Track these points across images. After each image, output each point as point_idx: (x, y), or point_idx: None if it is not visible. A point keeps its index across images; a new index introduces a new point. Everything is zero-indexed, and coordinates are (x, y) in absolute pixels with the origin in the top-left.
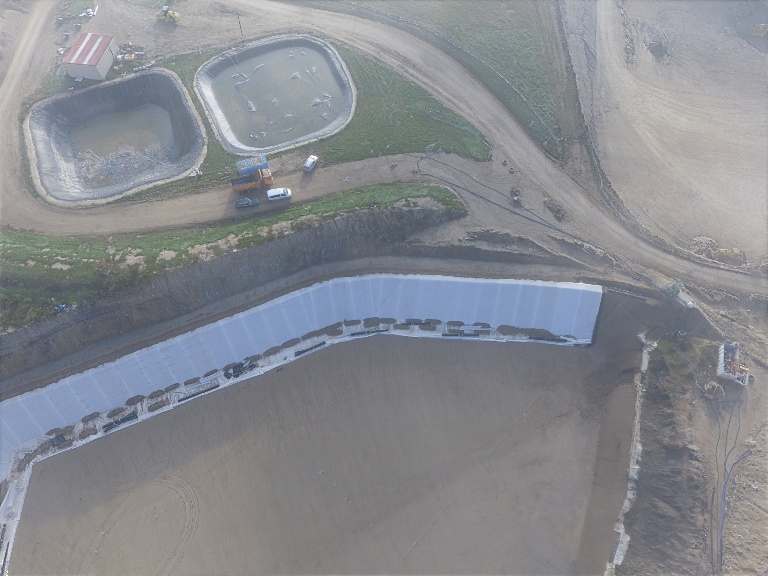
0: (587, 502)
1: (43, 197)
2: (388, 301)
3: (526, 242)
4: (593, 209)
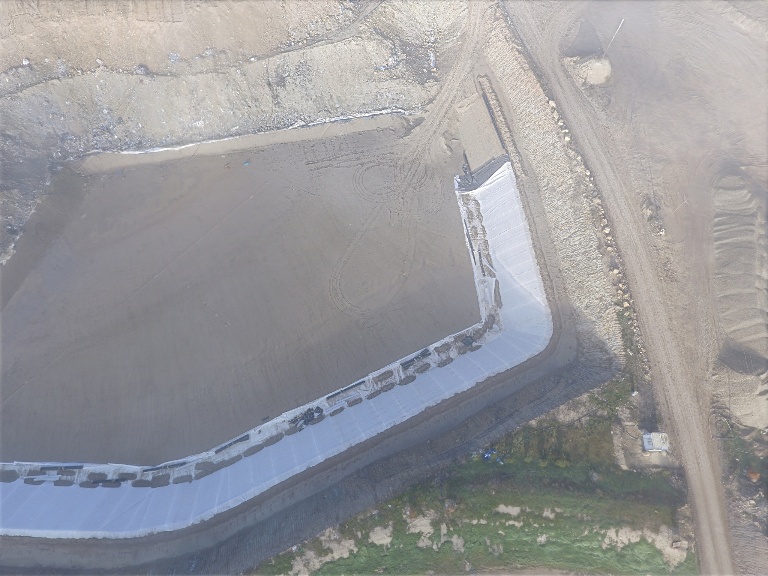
0: (3, 310)
1: None
2: (131, 505)
3: None
4: None
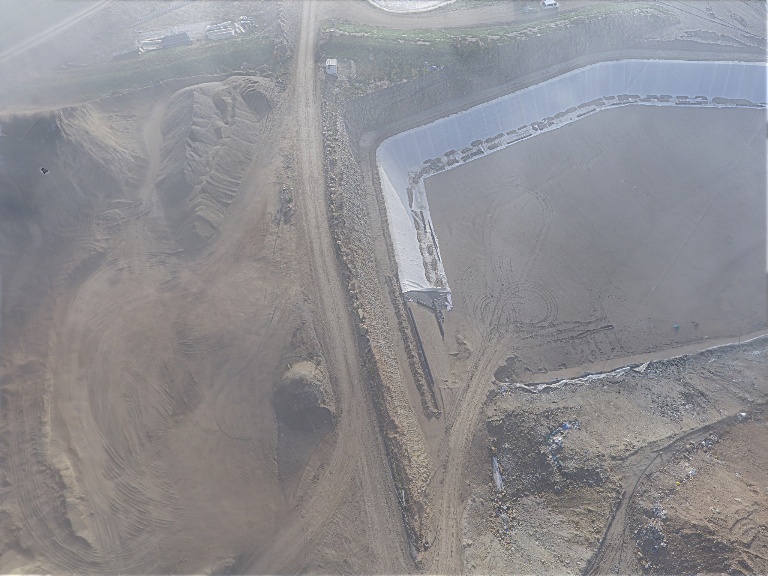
0: None
1: (380, 8)
2: (635, 81)
3: (727, 38)
4: (765, 21)
